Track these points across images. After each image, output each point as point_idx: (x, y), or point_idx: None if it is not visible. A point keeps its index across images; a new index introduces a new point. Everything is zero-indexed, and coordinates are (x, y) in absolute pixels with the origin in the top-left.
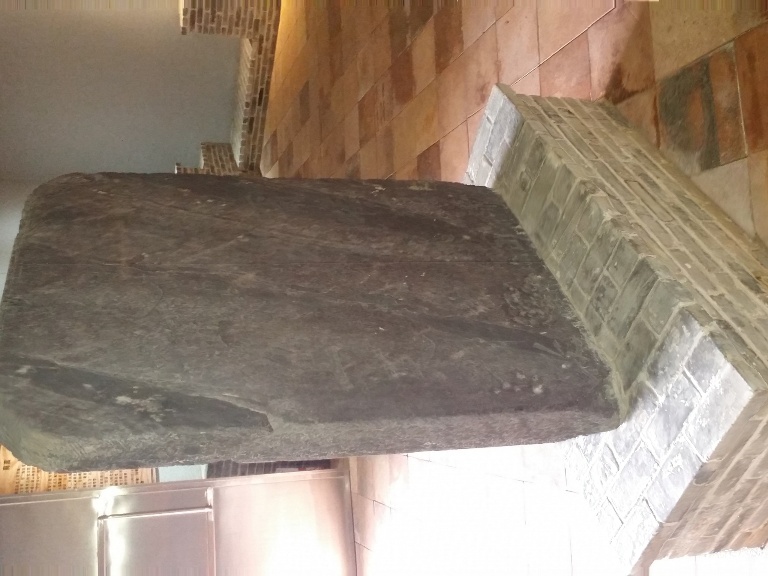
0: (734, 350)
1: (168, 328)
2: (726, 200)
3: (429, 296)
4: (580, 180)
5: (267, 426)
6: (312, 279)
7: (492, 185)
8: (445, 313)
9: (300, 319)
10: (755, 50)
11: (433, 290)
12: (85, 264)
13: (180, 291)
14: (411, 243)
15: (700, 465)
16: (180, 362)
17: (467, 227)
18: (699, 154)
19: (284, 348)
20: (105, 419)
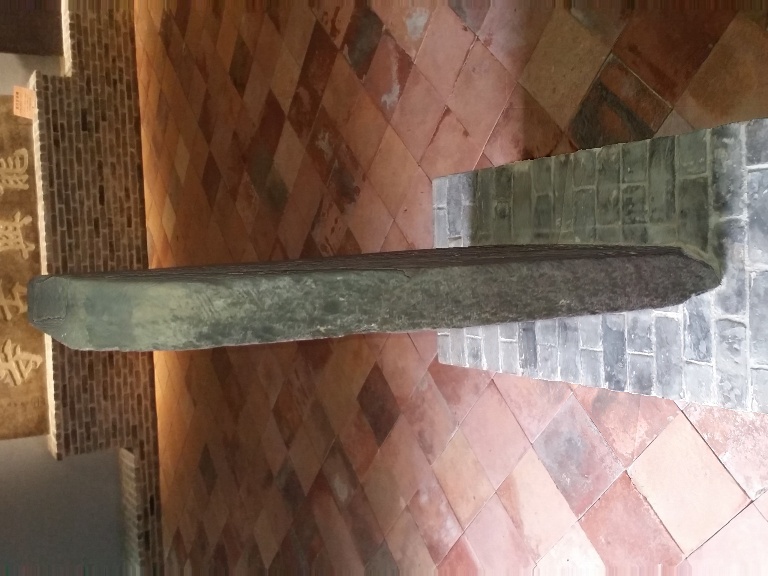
0: None
1: (246, 267)
2: None
3: None
4: None
5: (403, 271)
6: None
7: None
8: (503, 251)
9: None
10: (633, 41)
11: None
12: None
13: None
14: None
15: None
16: None
17: None
18: None
19: None
20: None
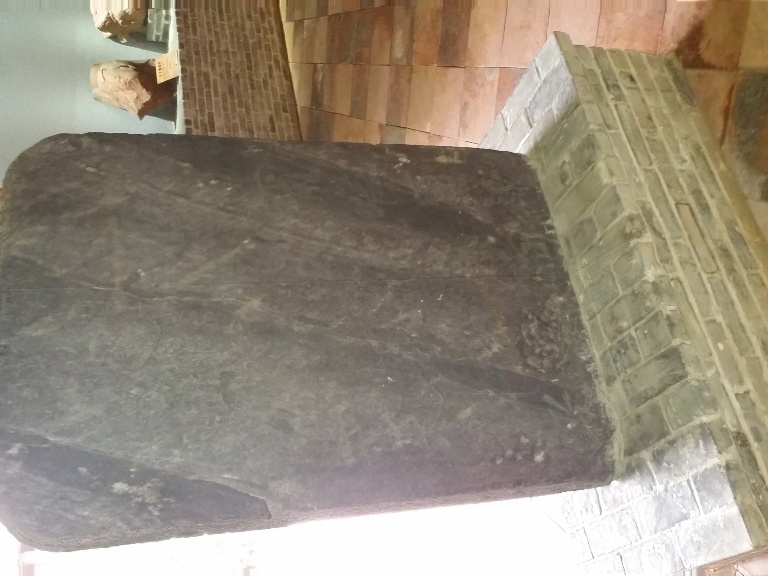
0: (745, 487)
1: (166, 384)
2: None
3: (443, 330)
4: (628, 214)
5: (266, 515)
6: (321, 307)
7: (528, 150)
8: (458, 355)
9: (306, 367)
10: None
11: (448, 321)
12: (75, 289)
13: (179, 328)
14: (431, 249)
15: (681, 568)
16: (179, 433)
17: (494, 223)
18: (764, 179)
19: (287, 409)
20: (102, 514)
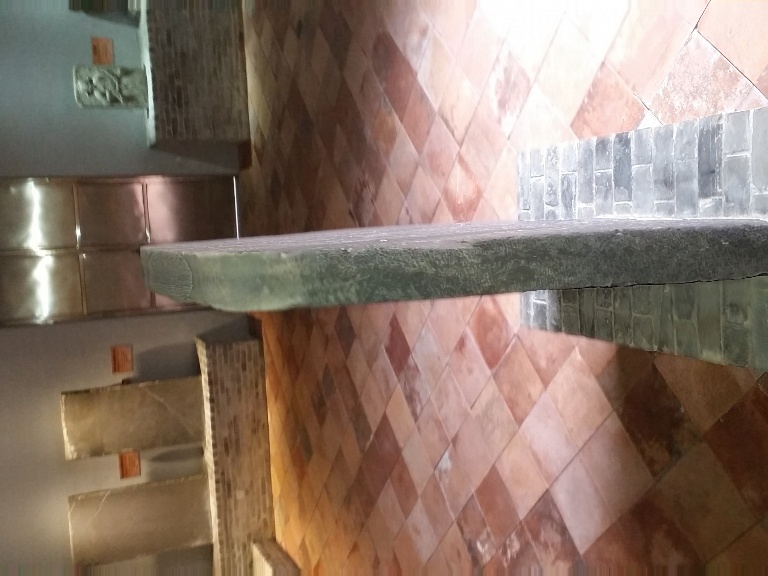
0: None
1: None
2: None
3: None
4: None
5: None
6: None
7: None
8: None
9: None
10: None
11: None
12: None
13: None
14: None
15: None
16: None
17: None
18: None
19: None
20: None
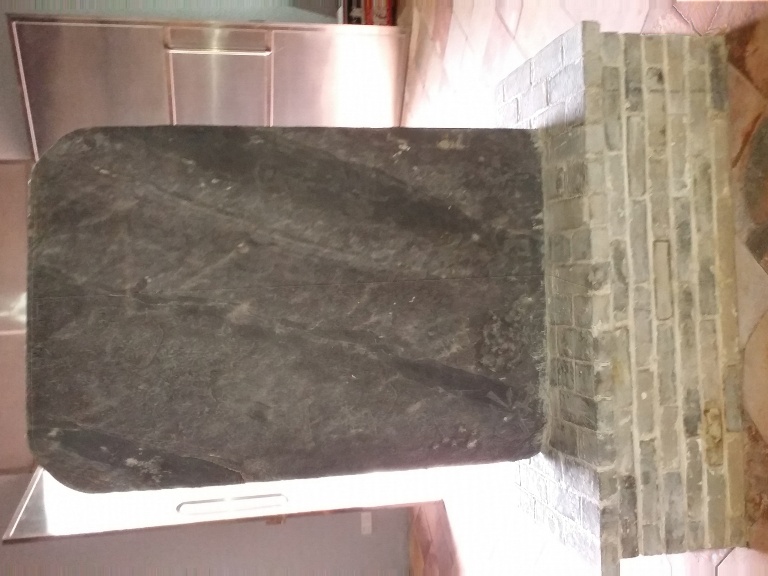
0: (614, 527)
1: (167, 381)
2: (744, 295)
3: (409, 331)
4: (594, 264)
5: None
6: (302, 310)
7: (540, 126)
8: (418, 355)
9: (283, 366)
10: None
11: (416, 323)
12: (93, 296)
13: (179, 331)
14: (413, 249)
15: None
16: (176, 421)
17: (482, 219)
18: (753, 228)
19: (264, 403)
20: (119, 480)
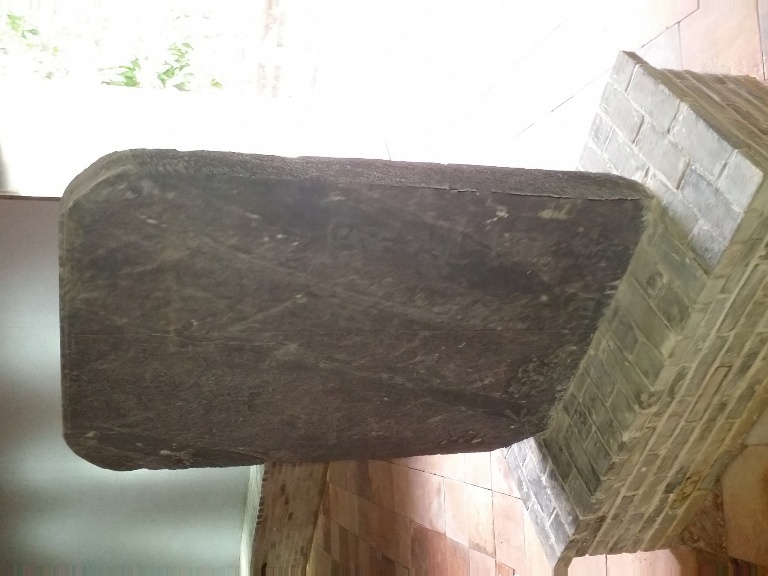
0: None
1: (205, 400)
2: None
3: (450, 368)
4: (652, 391)
5: None
6: (350, 350)
7: (658, 197)
8: (452, 385)
9: (320, 391)
10: None
11: (458, 363)
12: (134, 335)
13: (222, 364)
14: (478, 306)
15: None
16: (210, 427)
17: (557, 284)
18: None
19: (296, 415)
20: (152, 463)
